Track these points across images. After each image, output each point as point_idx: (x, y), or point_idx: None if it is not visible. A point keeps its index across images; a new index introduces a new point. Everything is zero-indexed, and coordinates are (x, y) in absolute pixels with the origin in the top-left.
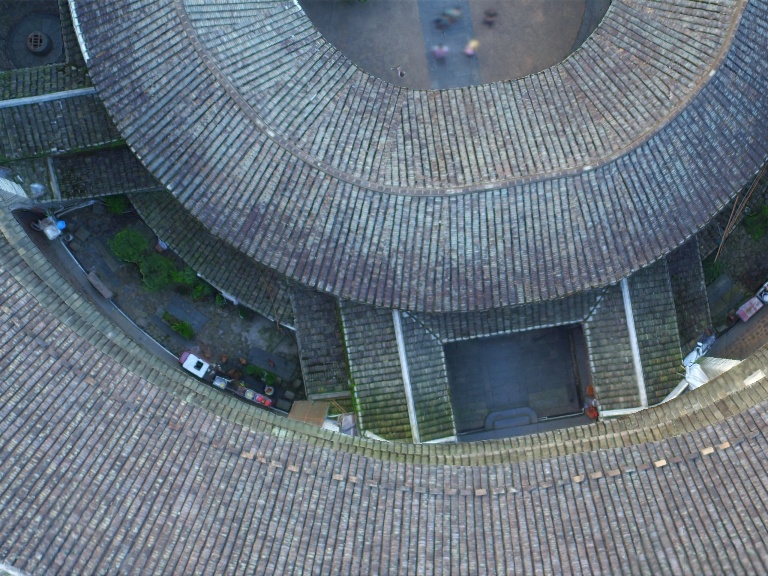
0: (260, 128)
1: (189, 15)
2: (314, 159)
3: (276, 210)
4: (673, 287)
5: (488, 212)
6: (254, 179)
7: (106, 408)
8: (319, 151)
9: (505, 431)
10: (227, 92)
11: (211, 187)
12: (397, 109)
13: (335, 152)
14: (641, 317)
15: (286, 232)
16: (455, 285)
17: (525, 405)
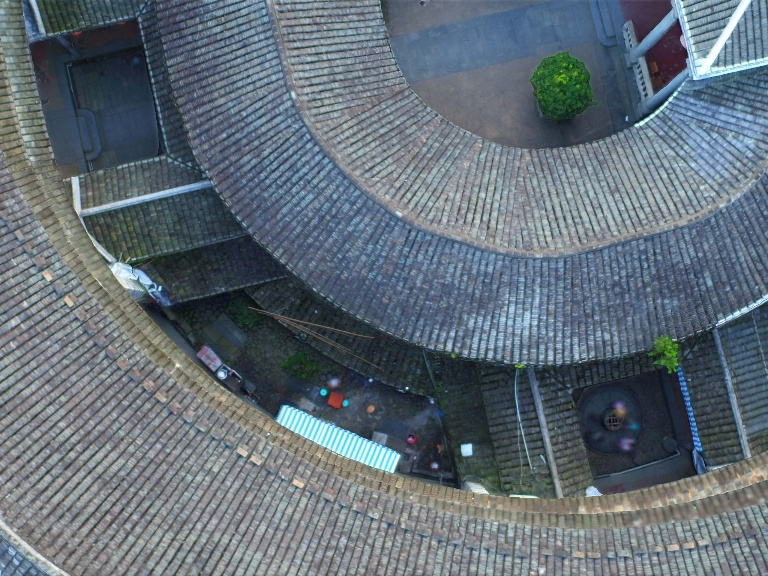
0: None
1: None
2: None
3: None
4: (215, 255)
5: (247, 8)
6: None
7: None
8: None
9: (75, 126)
10: None
11: None
12: None
13: None
14: (173, 206)
15: None
16: None
17: (104, 147)
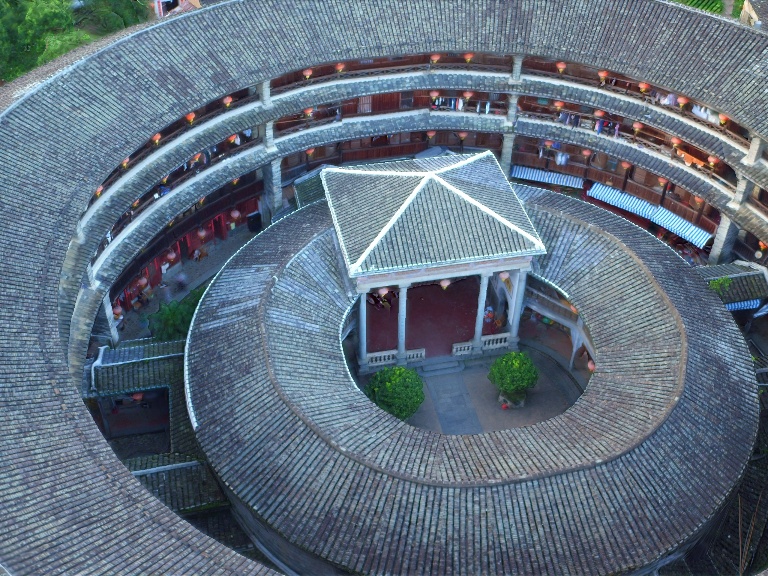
0: (334, 447)
1: (280, 383)
2: (378, 465)
3: (347, 513)
4: None
5: (525, 501)
6: (329, 489)
7: (218, 574)
8: (382, 462)
9: None
10: (308, 426)
11: (292, 502)
12: (440, 444)
13: (394, 464)
14: None
15: (356, 531)
16: (507, 568)
17: None
